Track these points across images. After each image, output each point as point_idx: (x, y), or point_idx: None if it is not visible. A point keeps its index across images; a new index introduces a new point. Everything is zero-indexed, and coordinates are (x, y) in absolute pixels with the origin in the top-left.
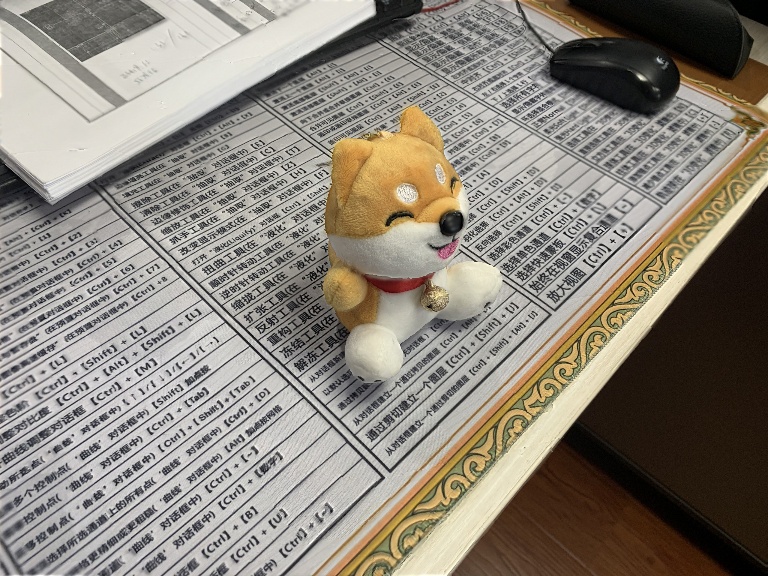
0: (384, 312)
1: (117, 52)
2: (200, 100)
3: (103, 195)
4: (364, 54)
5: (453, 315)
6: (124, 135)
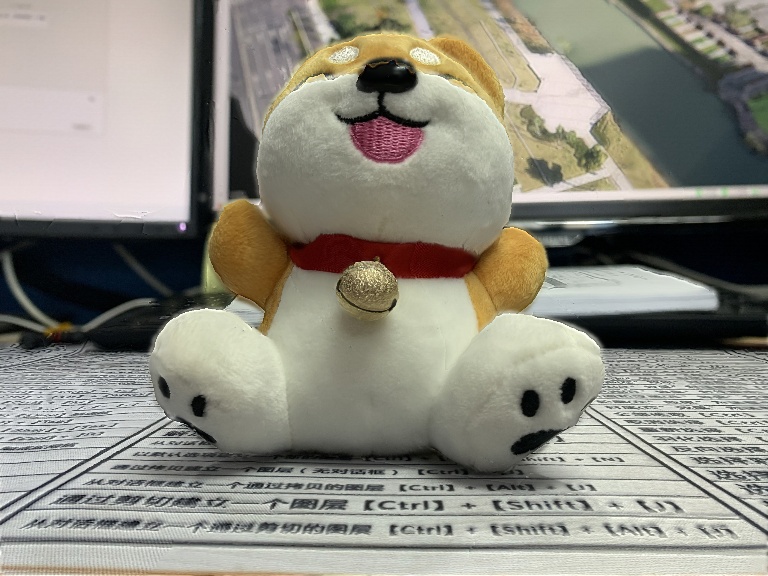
0: (282, 307)
1: None
2: None
3: None
4: (691, 352)
5: (447, 412)
6: None
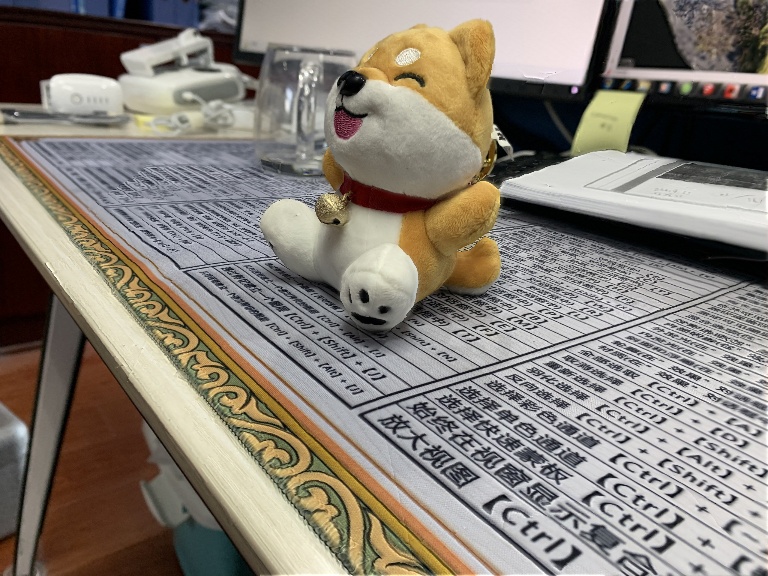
0: None
1: (688, 186)
2: (660, 214)
3: (530, 225)
4: None
5: None
6: (577, 193)
